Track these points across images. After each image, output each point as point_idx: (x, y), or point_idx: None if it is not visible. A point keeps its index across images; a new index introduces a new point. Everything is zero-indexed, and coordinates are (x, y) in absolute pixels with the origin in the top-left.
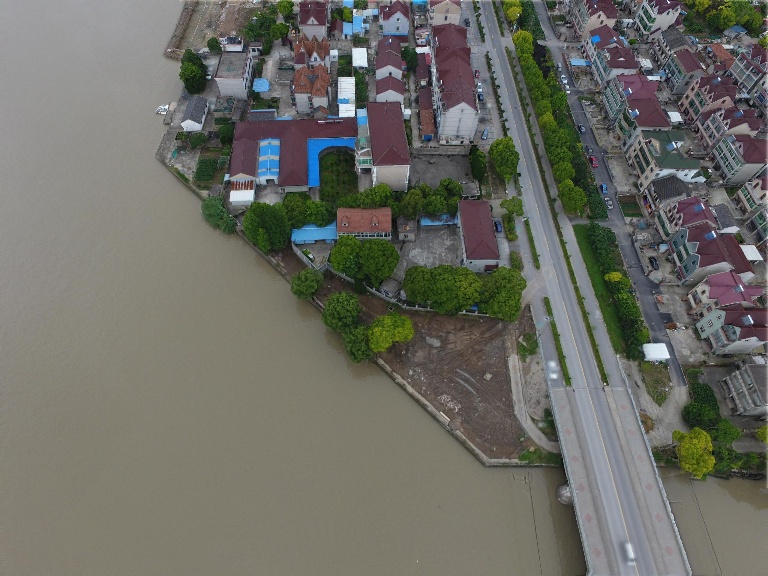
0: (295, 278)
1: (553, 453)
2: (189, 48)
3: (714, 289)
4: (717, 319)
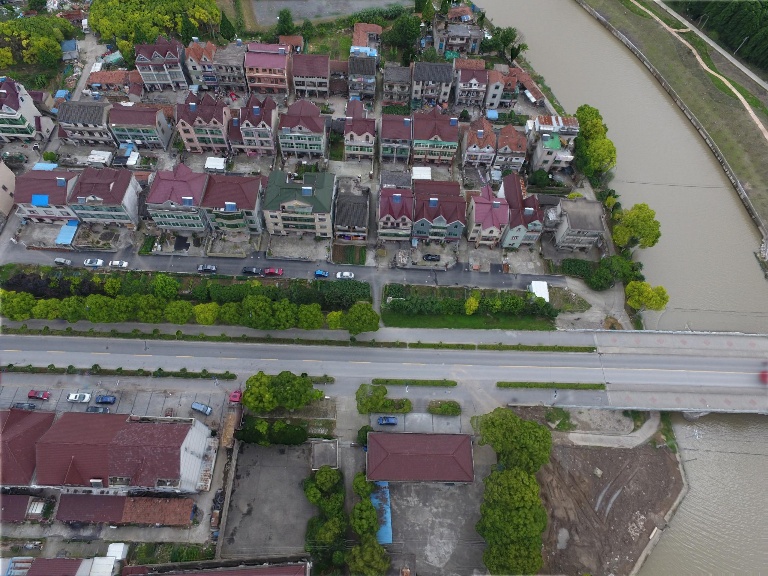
0: None
1: (661, 417)
2: None
3: (495, 223)
4: (518, 232)
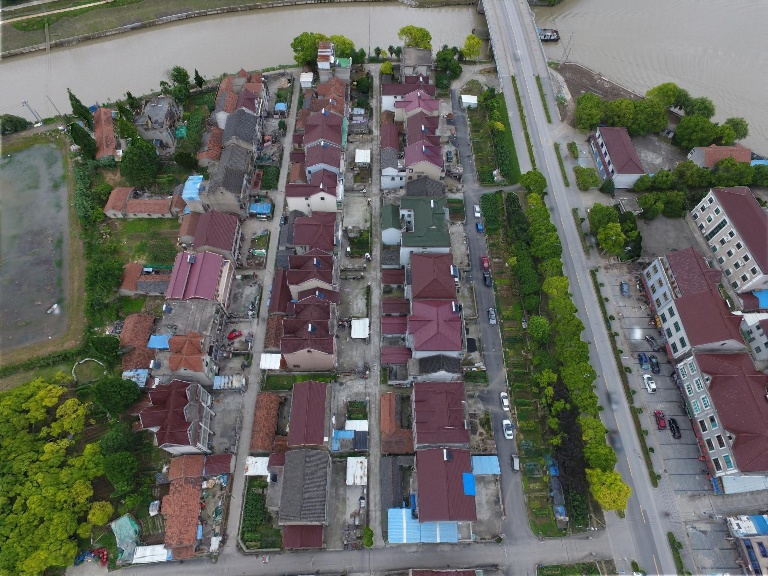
0: None
1: None
2: None
3: None
4: None
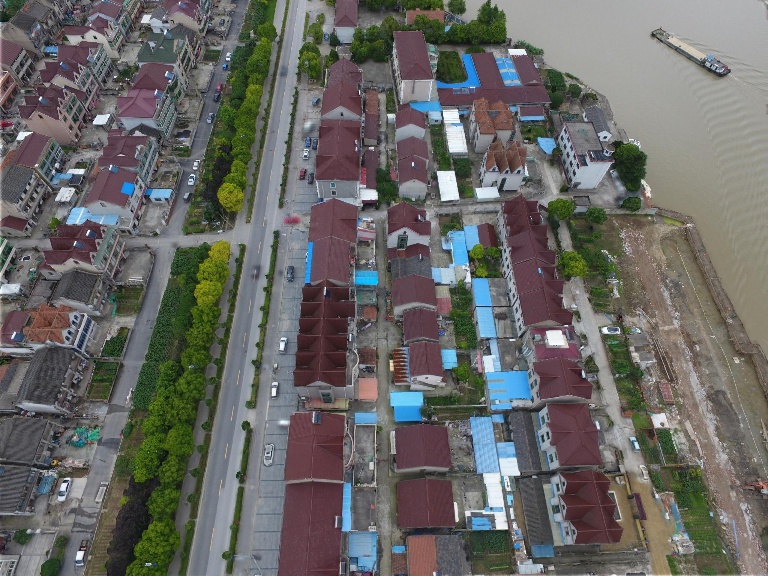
0: (463, 2)
1: None
2: (671, 233)
3: None
4: None
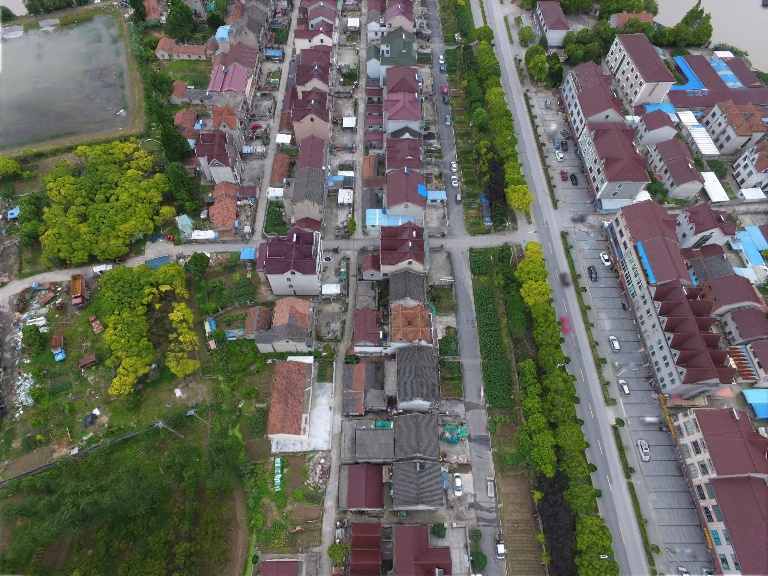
0: None
1: None
2: None
3: None
4: None
